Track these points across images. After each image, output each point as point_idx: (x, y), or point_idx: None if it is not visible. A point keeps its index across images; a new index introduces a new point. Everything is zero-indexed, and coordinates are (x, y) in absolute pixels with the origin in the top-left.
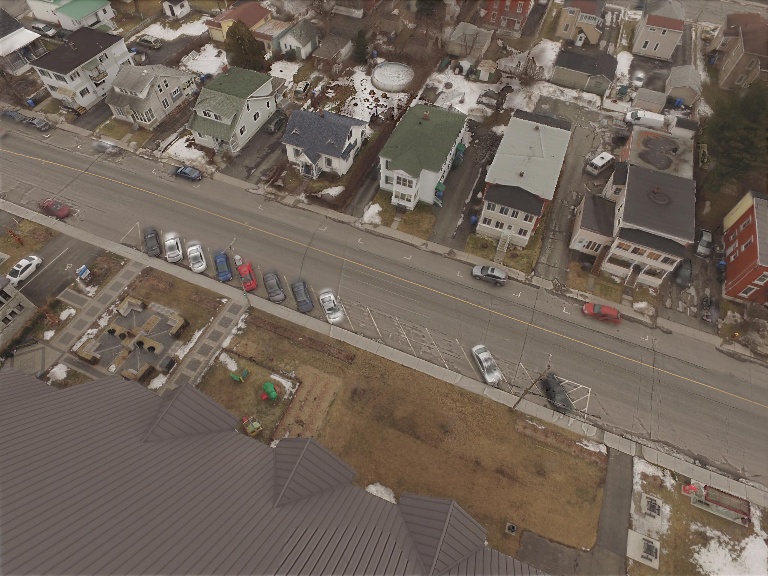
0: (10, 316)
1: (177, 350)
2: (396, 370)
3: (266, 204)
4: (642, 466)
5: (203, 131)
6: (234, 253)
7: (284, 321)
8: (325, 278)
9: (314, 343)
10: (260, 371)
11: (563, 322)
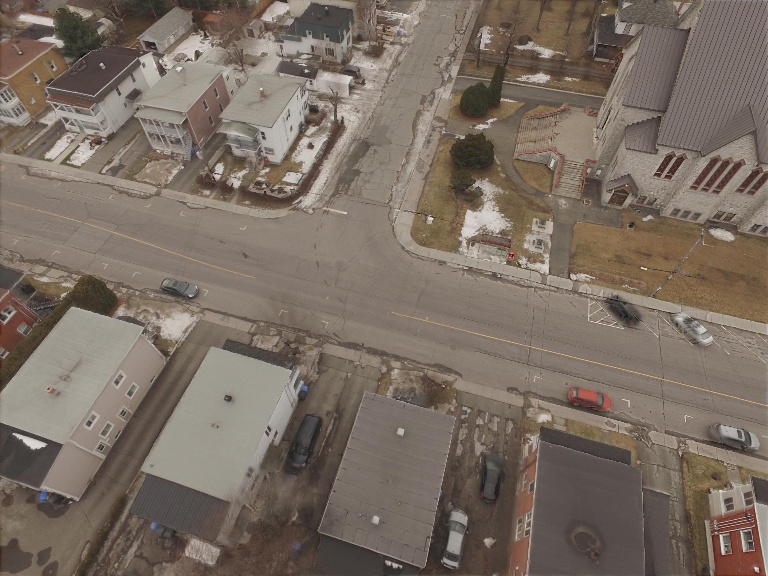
0: None
1: None
2: (767, 318)
3: None
4: (544, 267)
5: None
6: None
7: None
8: None
9: None
10: None
11: (628, 387)
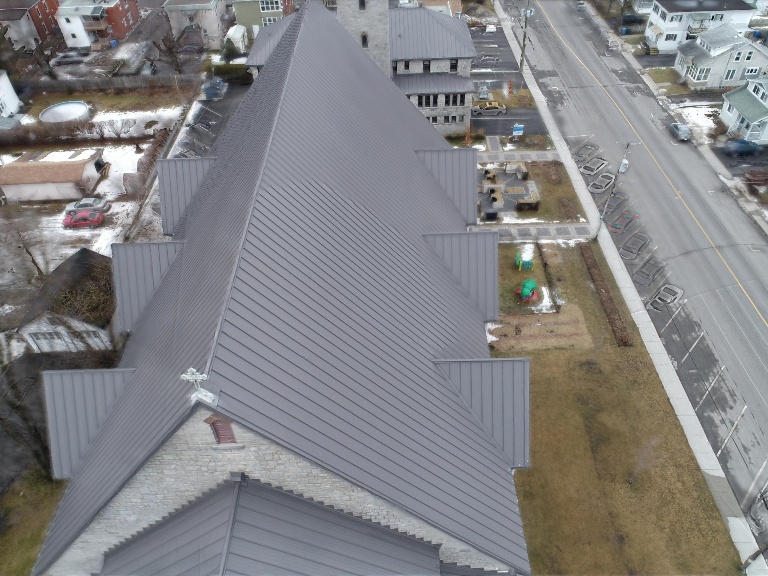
0: (451, 119)
1: (508, 216)
2: (655, 394)
3: (721, 194)
4: None
5: (736, 103)
6: (637, 201)
7: (608, 270)
8: (694, 278)
9: (610, 303)
10: (540, 277)
11: None
